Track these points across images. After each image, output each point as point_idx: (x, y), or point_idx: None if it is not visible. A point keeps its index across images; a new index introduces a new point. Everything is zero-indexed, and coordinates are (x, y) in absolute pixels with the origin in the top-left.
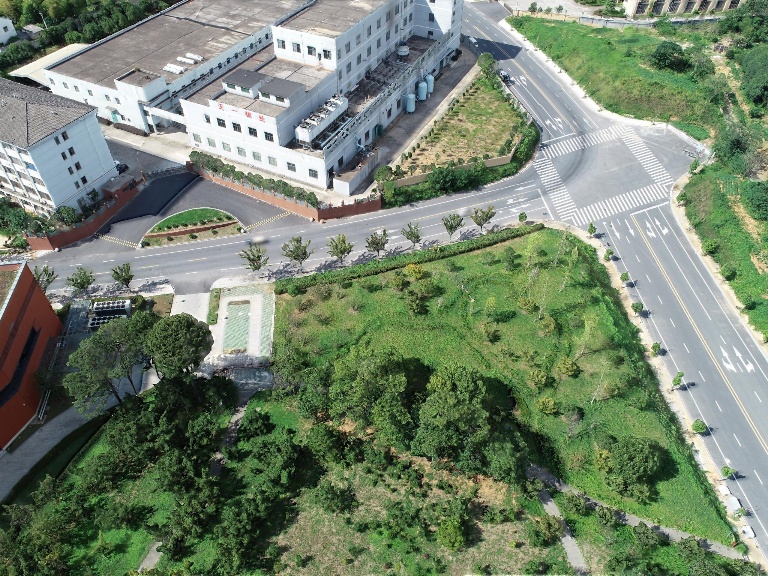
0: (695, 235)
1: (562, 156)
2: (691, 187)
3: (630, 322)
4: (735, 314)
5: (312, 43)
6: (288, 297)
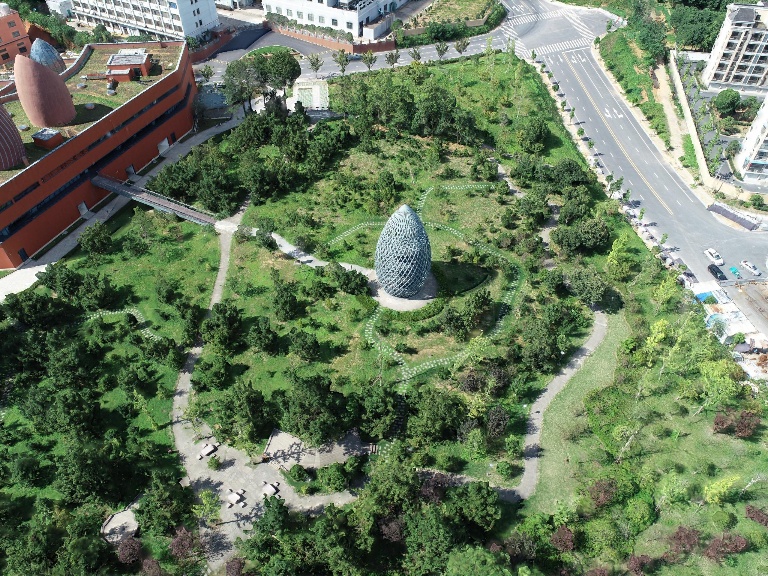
0: (603, 62)
1: (521, 24)
2: (606, 38)
3: (550, 96)
4: (619, 96)
5: None
6: None
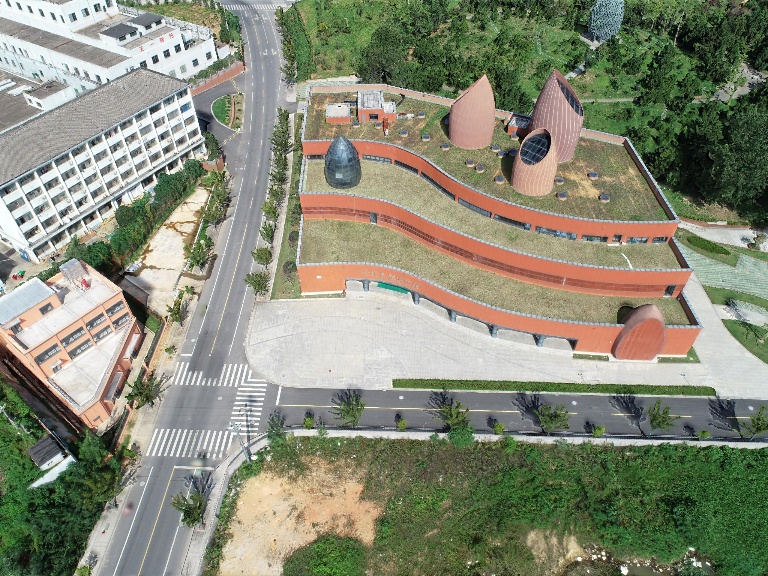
0: None
1: (222, 2)
2: None
3: None
4: None
5: (96, 0)
6: (315, 75)
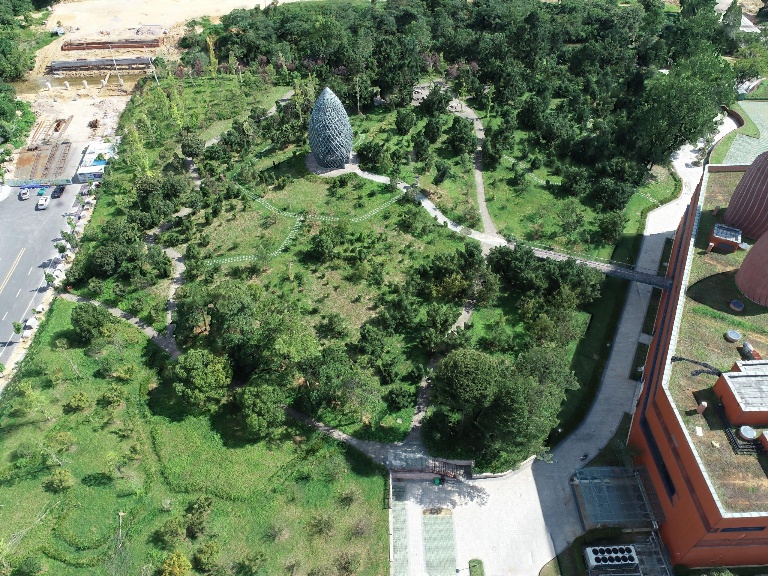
0: None
1: None
2: None
3: None
4: None
5: None
6: None
